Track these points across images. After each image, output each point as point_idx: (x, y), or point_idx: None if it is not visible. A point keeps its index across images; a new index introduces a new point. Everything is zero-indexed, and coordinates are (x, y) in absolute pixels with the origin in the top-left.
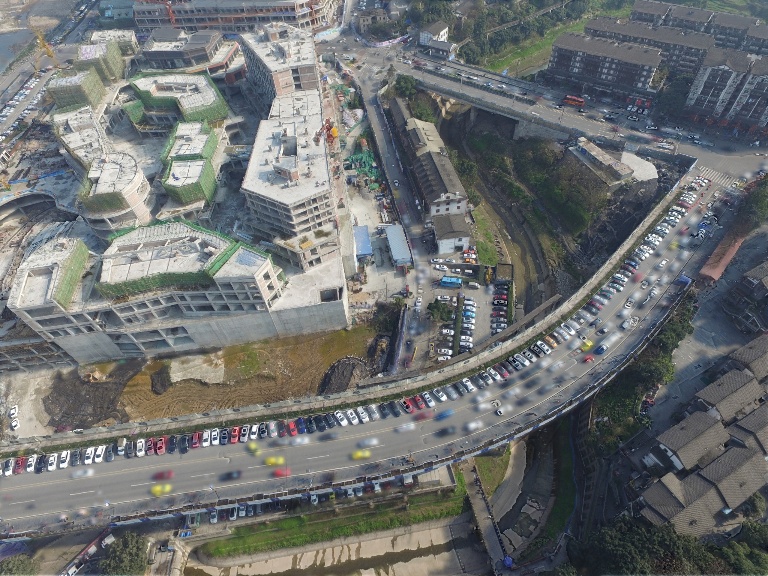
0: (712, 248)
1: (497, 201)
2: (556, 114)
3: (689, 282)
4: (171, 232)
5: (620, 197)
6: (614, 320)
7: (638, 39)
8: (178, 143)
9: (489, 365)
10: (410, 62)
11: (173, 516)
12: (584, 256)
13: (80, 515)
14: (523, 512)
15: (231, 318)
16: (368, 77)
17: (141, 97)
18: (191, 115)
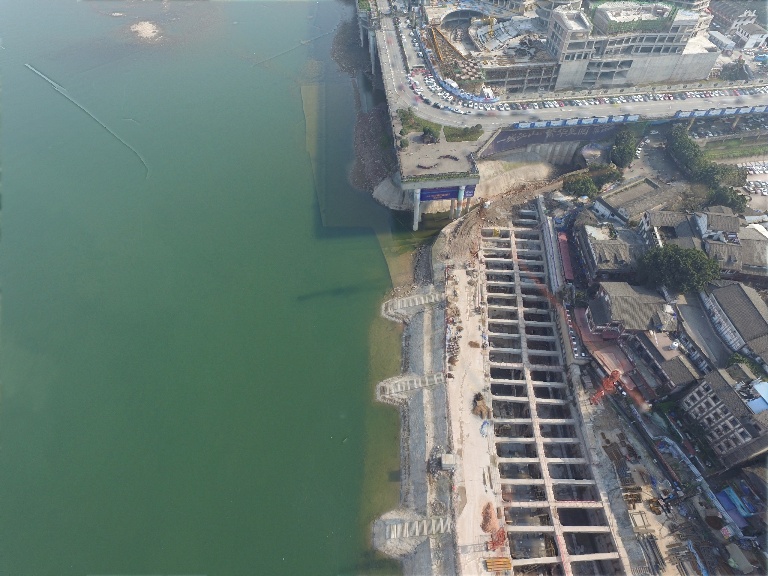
0: None
1: None
2: None
3: None
4: (627, 5)
5: None
6: None
7: None
8: None
9: None
10: None
11: (703, 115)
12: None
13: (652, 115)
14: None
15: (660, 57)
16: None
17: None
18: None
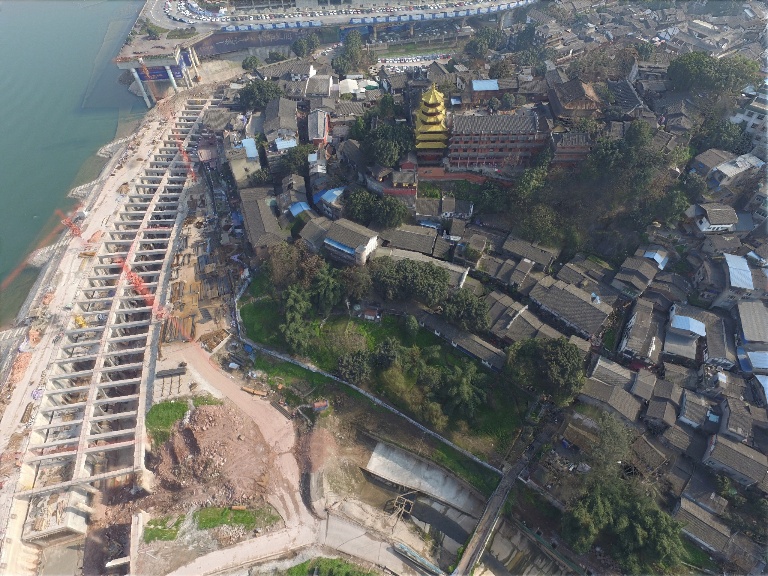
0: None
1: None
2: None
3: None
4: None
5: None
6: None
7: None
8: None
9: None
10: None
11: (373, 21)
12: None
13: (336, 22)
14: None
15: None
16: None
17: None
18: None
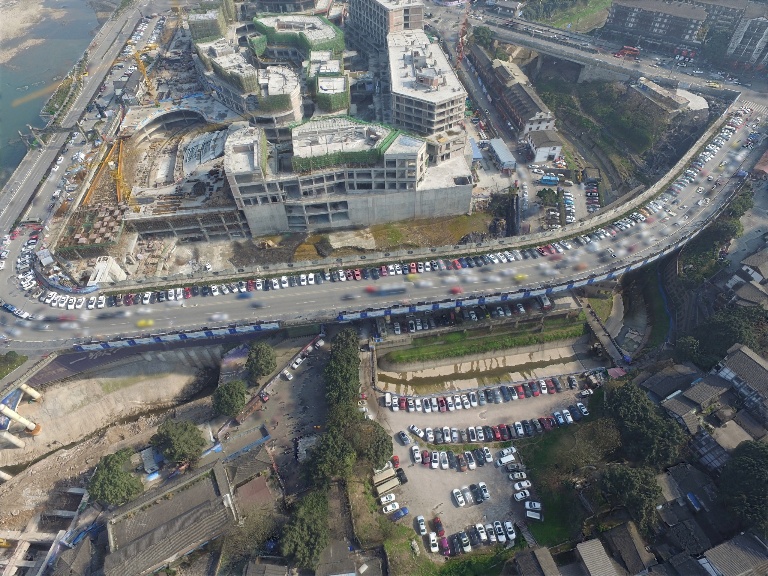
0: (760, 154)
1: (567, 132)
2: (616, 61)
3: (747, 174)
4: (337, 125)
5: (678, 122)
6: (691, 200)
7: (683, 1)
8: (314, 66)
9: (599, 227)
10: (481, 18)
11: (383, 314)
12: (650, 168)
13: (310, 314)
14: (627, 337)
15: (385, 195)
16: (446, 29)
17: (266, 33)
18: (317, 46)
